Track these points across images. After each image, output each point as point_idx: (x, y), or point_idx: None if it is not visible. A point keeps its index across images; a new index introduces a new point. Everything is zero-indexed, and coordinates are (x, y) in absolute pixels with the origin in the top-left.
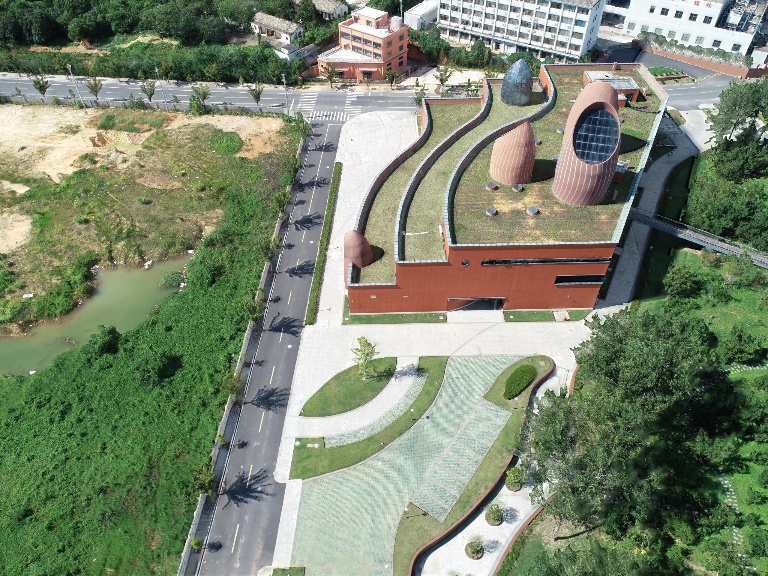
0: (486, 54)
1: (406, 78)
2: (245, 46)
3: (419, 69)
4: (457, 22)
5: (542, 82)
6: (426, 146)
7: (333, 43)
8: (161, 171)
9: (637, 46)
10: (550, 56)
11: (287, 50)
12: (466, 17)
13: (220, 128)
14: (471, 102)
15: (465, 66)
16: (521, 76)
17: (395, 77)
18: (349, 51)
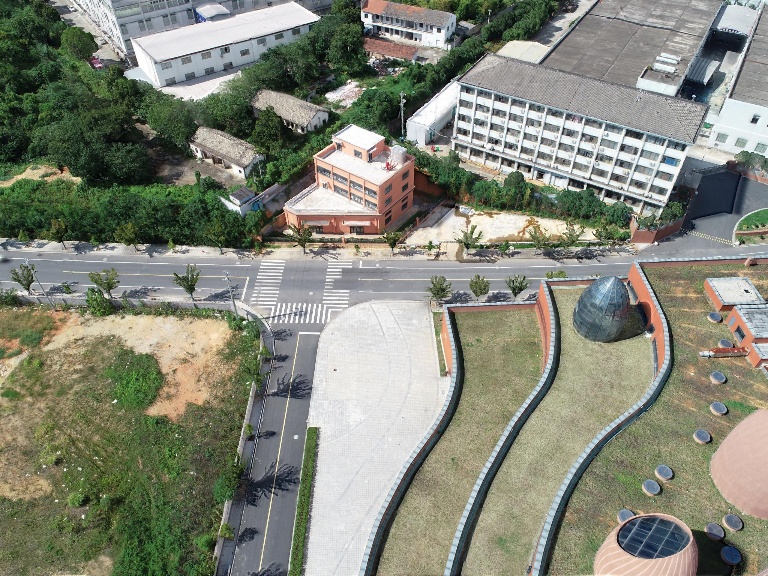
0: (527, 194)
1: (413, 230)
2: (179, 185)
3: (430, 212)
4: (482, 139)
5: (636, 290)
6: (457, 419)
7: (307, 175)
8: (22, 453)
9: (734, 170)
10: (619, 196)
11: (238, 200)
12: (496, 135)
13: (130, 345)
14: (519, 308)
15: (496, 207)
16: (614, 305)
17: (397, 229)
18: (330, 191)
